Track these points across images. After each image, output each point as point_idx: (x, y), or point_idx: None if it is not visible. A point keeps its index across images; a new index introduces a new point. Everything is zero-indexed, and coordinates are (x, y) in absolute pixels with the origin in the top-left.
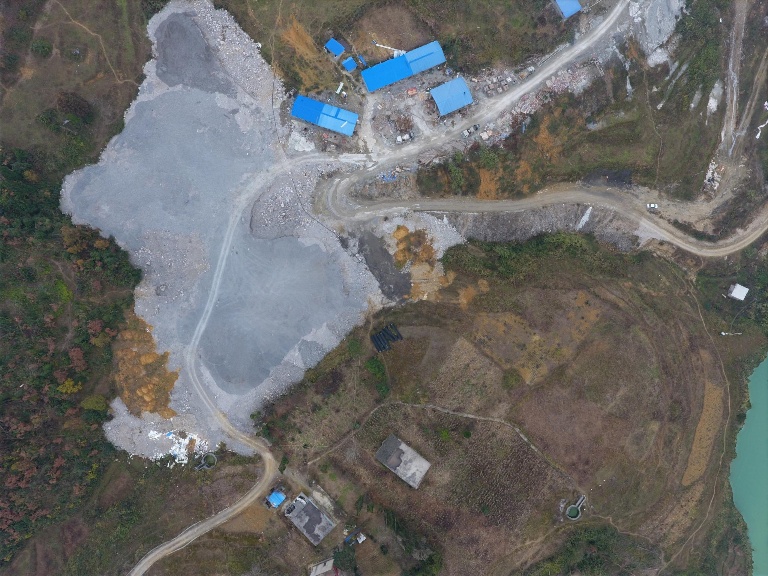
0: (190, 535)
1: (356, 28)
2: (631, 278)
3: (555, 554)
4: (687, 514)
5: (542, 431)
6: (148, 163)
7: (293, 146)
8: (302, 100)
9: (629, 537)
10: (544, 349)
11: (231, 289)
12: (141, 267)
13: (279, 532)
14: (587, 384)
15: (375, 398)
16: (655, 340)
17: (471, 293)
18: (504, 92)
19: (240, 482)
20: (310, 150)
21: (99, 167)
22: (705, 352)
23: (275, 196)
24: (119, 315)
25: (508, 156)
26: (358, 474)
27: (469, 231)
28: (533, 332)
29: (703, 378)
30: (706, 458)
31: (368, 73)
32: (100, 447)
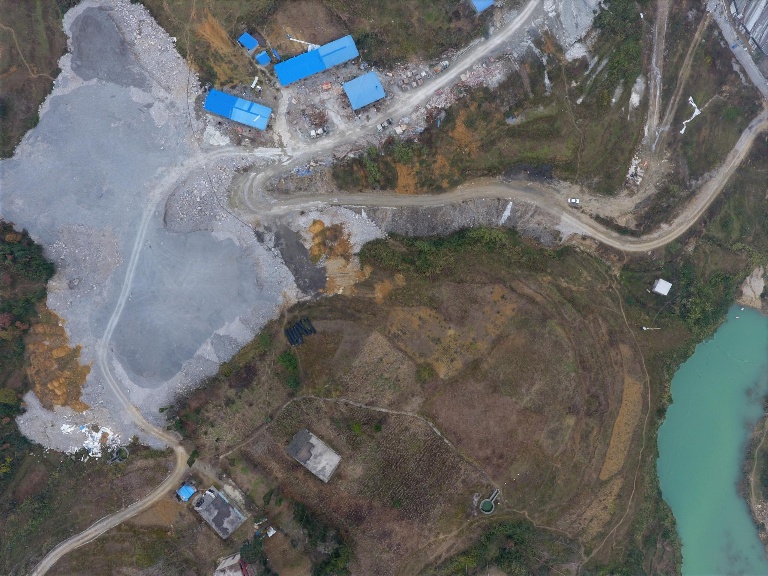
0: (99, 528)
1: (270, 22)
2: (550, 273)
3: (469, 548)
4: (606, 508)
5: (456, 425)
6: (62, 157)
7: (208, 140)
8: (215, 94)
9: (546, 531)
10: (459, 343)
11: (144, 283)
12: (55, 261)
13: (189, 525)
14: (502, 378)
15: (288, 392)
16: (572, 334)
17: (387, 287)
18: (419, 86)
19: (151, 476)
20: (225, 144)
21: (13, 161)
22: (625, 347)
23: (191, 190)
24: (31, 309)
25: (422, 150)
26: (270, 468)
27: (389, 226)
28: (448, 326)
29: (622, 373)
30: (624, 452)
31: (281, 67)
32: (13, 441)
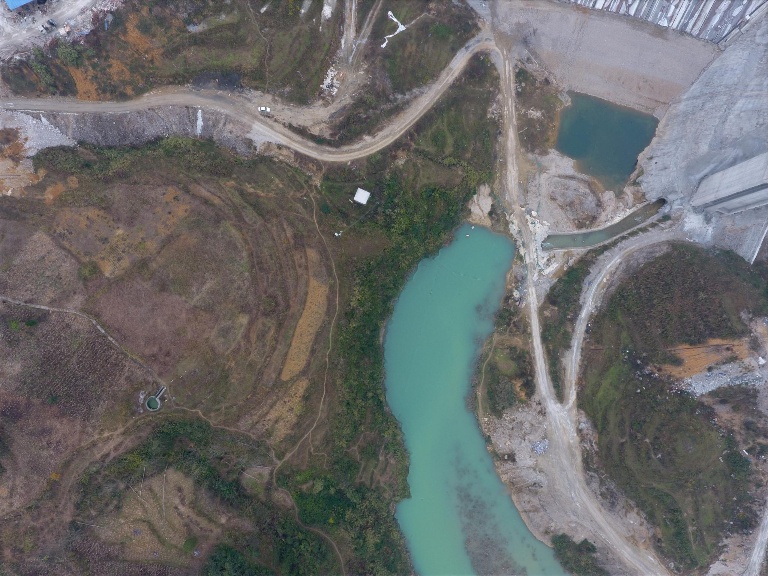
0: None
1: None
2: (235, 178)
3: (137, 446)
4: (292, 410)
5: (120, 323)
6: None
7: None
8: None
9: (224, 431)
10: (127, 243)
11: None
12: None
13: None
14: (172, 277)
15: None
16: (250, 236)
17: (60, 189)
18: None
19: None
20: None
21: None
22: (312, 251)
23: None
24: None
25: (87, 52)
26: None
27: (76, 133)
28: (117, 226)
29: (306, 275)
30: (306, 353)
31: None
32: None
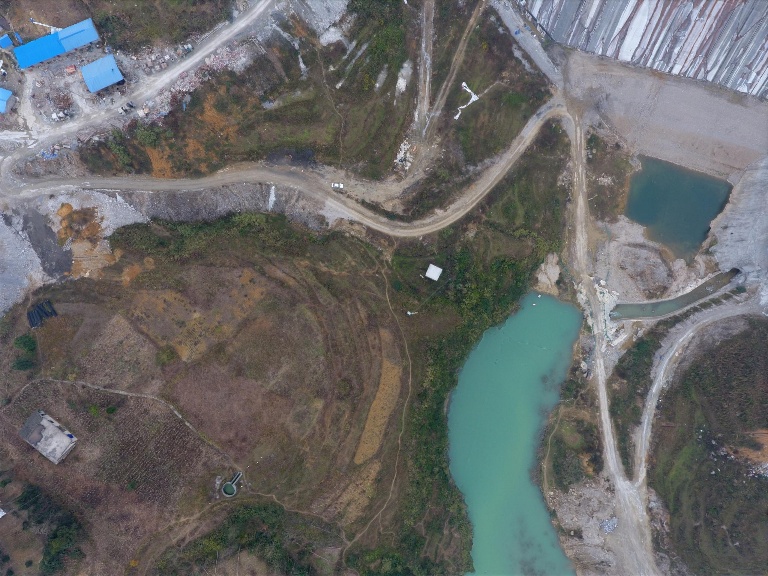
0: None
1: (12, 6)
2: (309, 257)
3: (212, 531)
4: (364, 493)
5: (197, 408)
6: None
7: None
8: None
9: (297, 515)
10: (204, 326)
11: None
12: None
13: None
14: (248, 362)
15: (27, 374)
16: (325, 318)
17: (136, 271)
18: (163, 70)
19: None
20: None
21: None
22: (385, 331)
23: None
24: None
25: (166, 134)
26: (6, 450)
27: (150, 210)
28: (193, 309)
29: (380, 357)
30: (379, 437)
31: (20, 50)
32: None
